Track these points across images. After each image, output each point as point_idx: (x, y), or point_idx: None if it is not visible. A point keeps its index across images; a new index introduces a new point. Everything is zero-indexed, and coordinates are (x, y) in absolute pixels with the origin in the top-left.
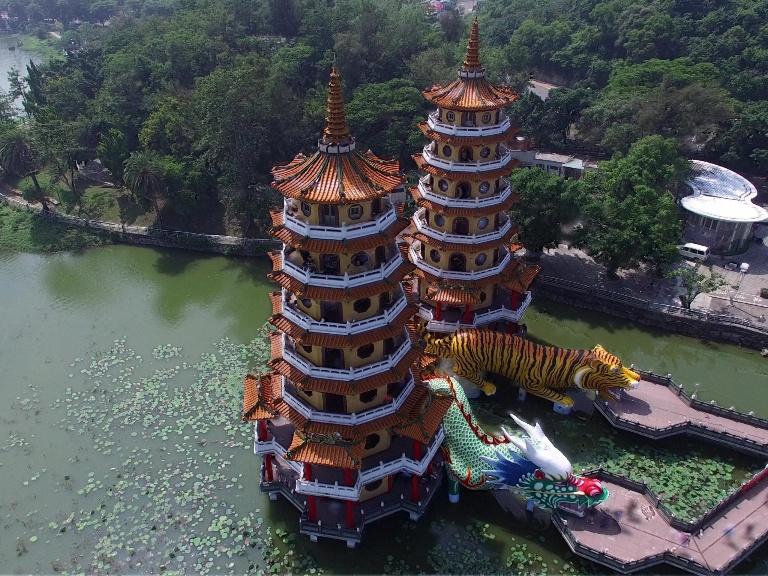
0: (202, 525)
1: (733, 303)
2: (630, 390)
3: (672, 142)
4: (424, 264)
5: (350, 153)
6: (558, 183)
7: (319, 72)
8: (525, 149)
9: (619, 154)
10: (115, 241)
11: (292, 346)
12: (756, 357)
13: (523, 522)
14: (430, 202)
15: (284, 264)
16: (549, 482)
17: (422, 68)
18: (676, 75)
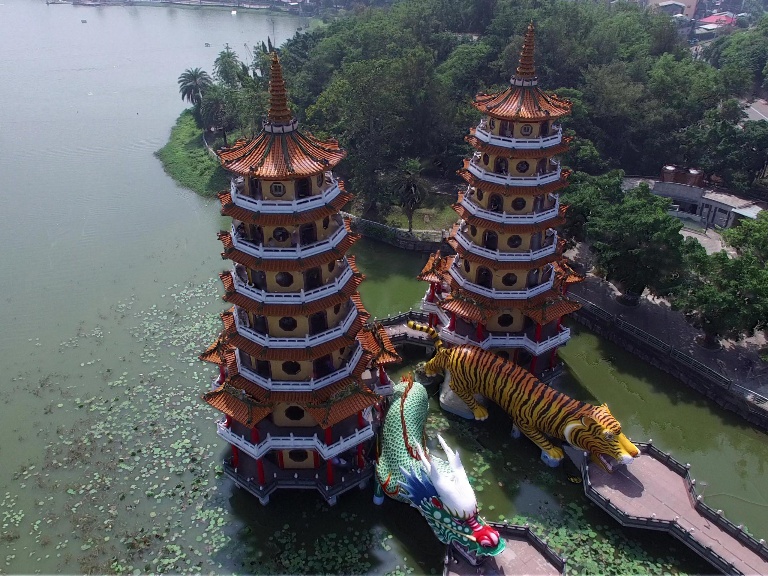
0: (169, 440)
1: None
2: (632, 465)
3: None
4: (455, 271)
5: (286, 134)
6: (657, 221)
7: (493, 72)
8: (695, 184)
9: None
10: None
11: None
12: None
13: None
14: (464, 208)
15: None
16: (447, 515)
17: (598, 80)
18: None
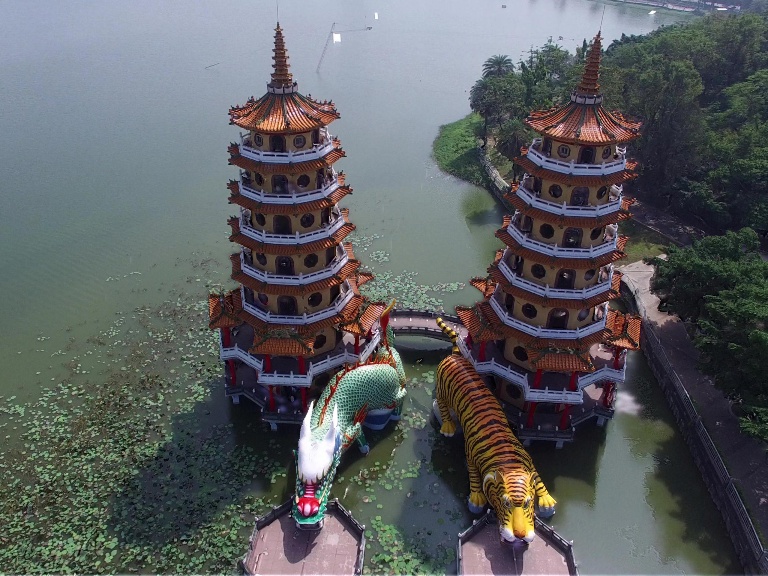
0: None
1: None
2: None
3: None
4: None
5: (278, 96)
6: None
7: None
8: None
9: None
10: (487, 186)
11: None
12: None
13: None
14: None
15: None
16: None
17: None
18: None
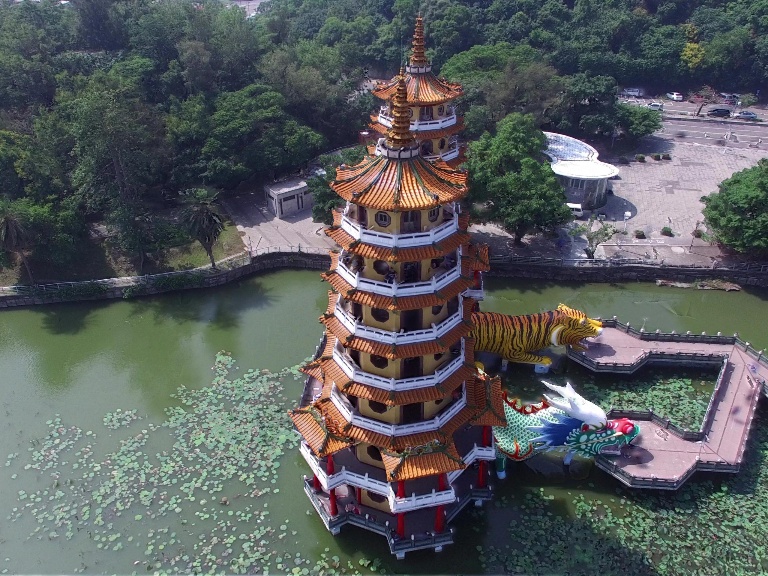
0: None
1: (621, 247)
2: (591, 338)
3: (531, 117)
4: None
5: (417, 156)
6: None
7: (164, 85)
8: None
9: (487, 134)
10: None
11: (356, 367)
12: (653, 288)
13: (555, 478)
14: None
15: (358, 282)
16: (592, 432)
17: (275, 72)
18: (504, 58)
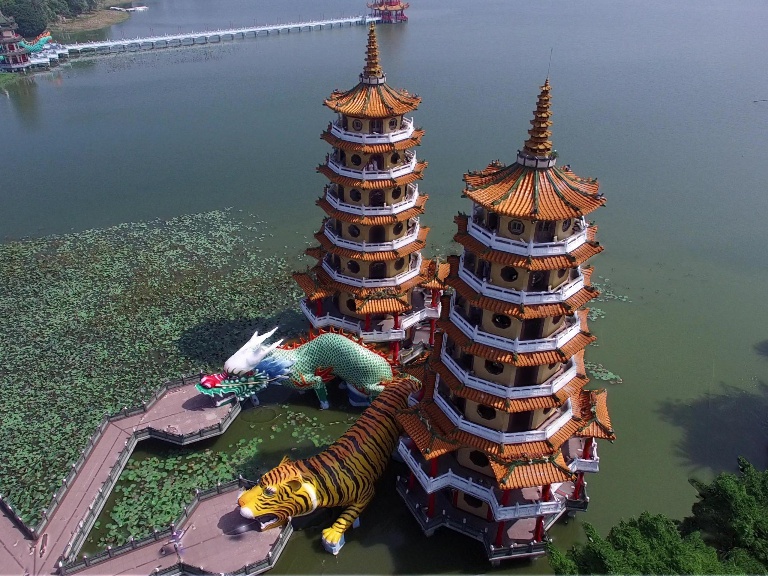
0: None
1: None
2: None
3: None
4: None
5: None
6: None
7: None
8: None
9: None
10: None
11: None
12: None
13: None
14: None
15: None
16: None
17: None
18: None
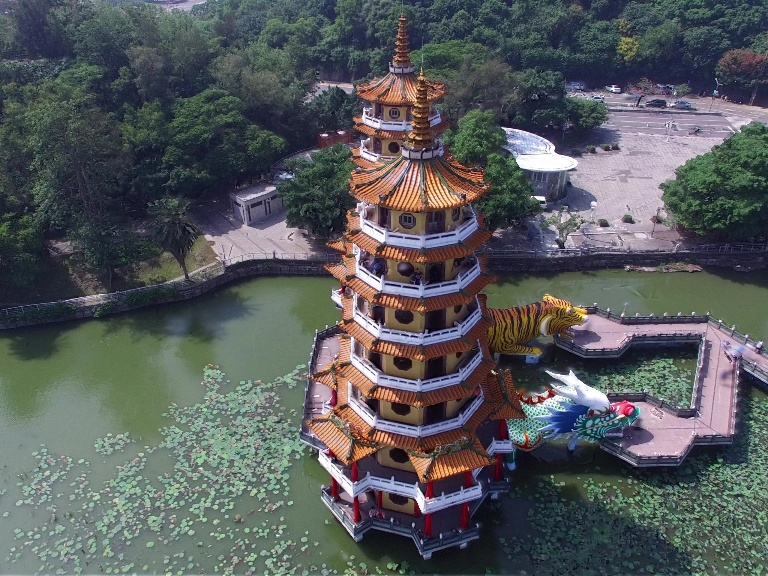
0: None
1: (588, 236)
2: None
3: (491, 113)
4: None
5: (437, 156)
6: None
7: (115, 93)
8: (349, 142)
9: (450, 131)
10: None
11: None
12: (621, 274)
13: (558, 464)
14: None
15: (383, 285)
16: (597, 417)
17: (230, 76)
18: (457, 56)
